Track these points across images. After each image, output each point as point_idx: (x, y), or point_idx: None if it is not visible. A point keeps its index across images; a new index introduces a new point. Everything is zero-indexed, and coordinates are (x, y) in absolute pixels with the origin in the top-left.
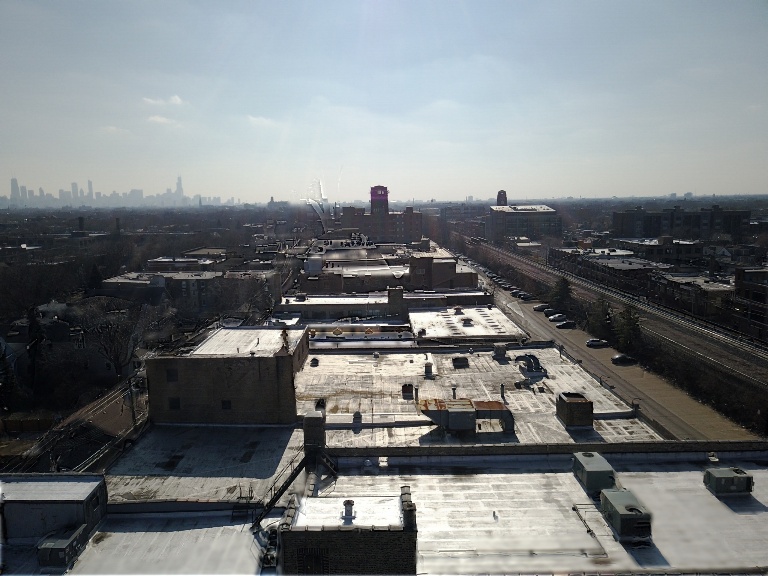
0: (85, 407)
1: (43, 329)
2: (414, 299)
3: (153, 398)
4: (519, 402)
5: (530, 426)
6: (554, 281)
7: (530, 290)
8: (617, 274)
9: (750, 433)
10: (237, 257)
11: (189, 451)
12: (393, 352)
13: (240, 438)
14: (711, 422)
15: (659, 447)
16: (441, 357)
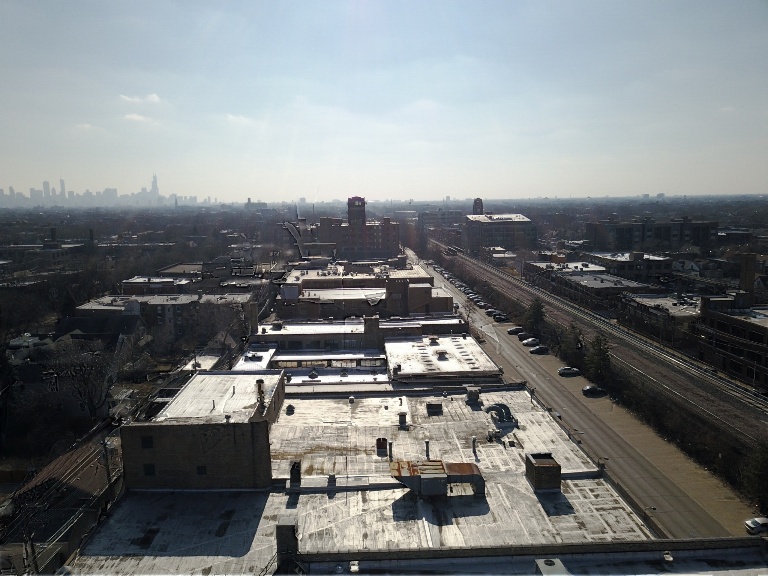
0: (59, 459)
1: (15, 371)
2: (390, 328)
3: (128, 465)
4: (490, 459)
5: (500, 488)
6: (528, 300)
7: (505, 309)
8: (589, 292)
9: (712, 476)
10: (213, 277)
11: (164, 524)
12: (368, 396)
13: (215, 506)
14: (676, 464)
15: (617, 547)
16: (415, 401)
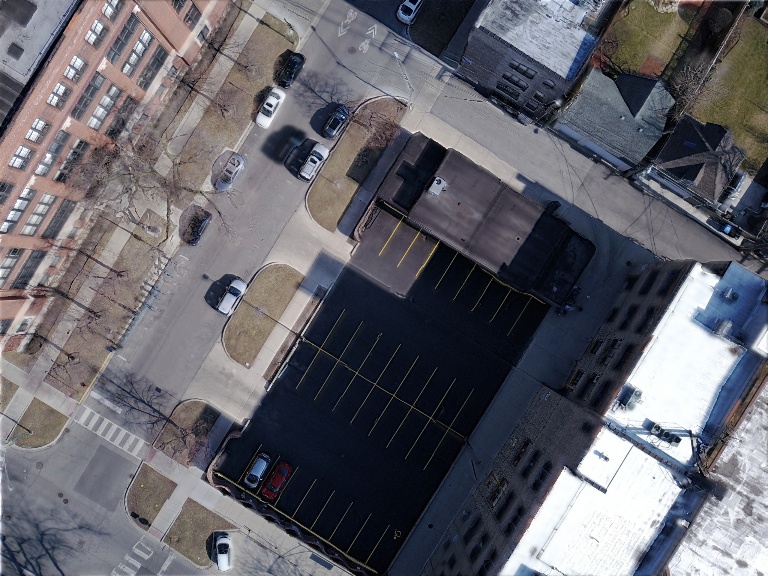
0: None
1: None
2: None
3: None
4: None
5: None
6: None
7: None
8: None
9: None
10: None
11: None
12: None
13: None
14: None
15: None
16: None
